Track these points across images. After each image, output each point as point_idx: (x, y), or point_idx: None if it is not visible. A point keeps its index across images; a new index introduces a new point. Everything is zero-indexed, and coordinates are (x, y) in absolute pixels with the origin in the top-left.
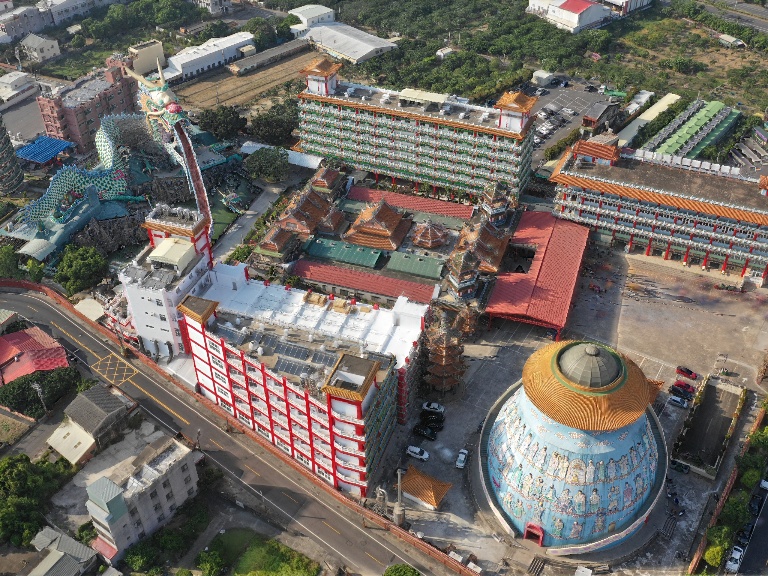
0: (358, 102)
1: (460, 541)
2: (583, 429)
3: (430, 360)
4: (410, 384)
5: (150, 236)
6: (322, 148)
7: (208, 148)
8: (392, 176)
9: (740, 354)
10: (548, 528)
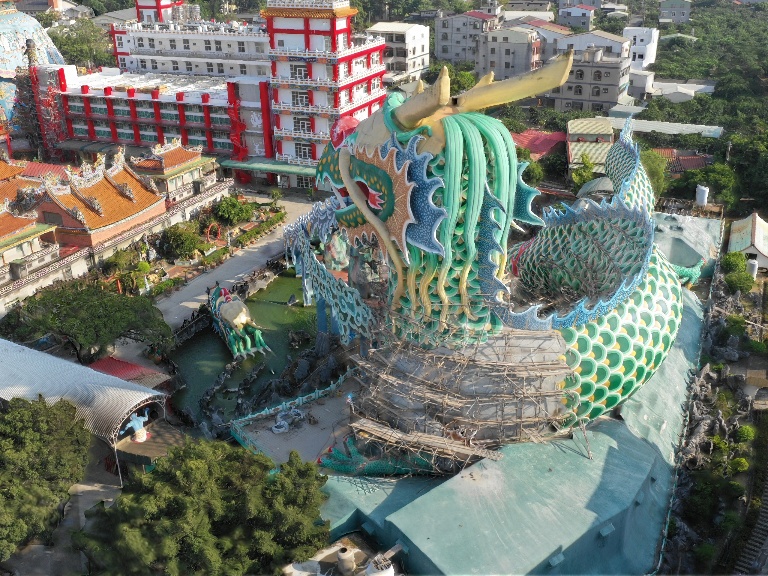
0: None
1: None
2: None
3: None
4: None
5: None
6: None
7: None
8: None
9: None
10: None
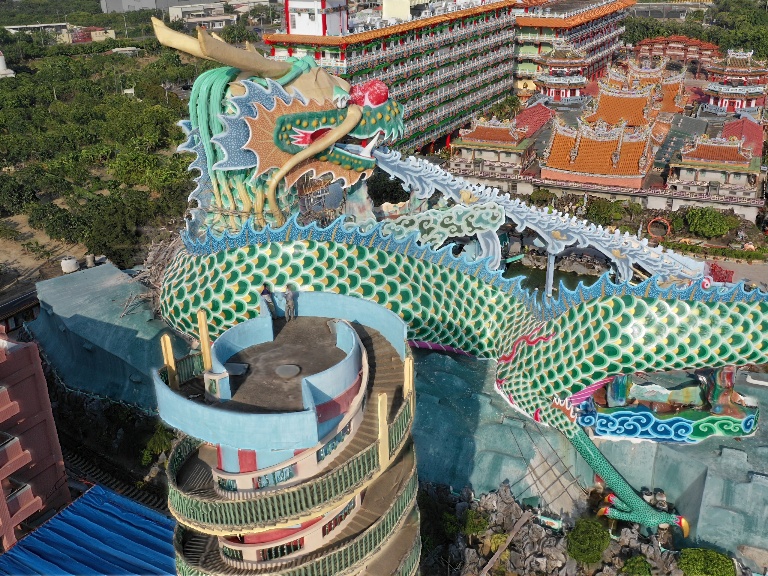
0: None
1: None
2: None
3: None
4: None
5: None
6: None
7: None
8: (434, 140)
9: None
10: None
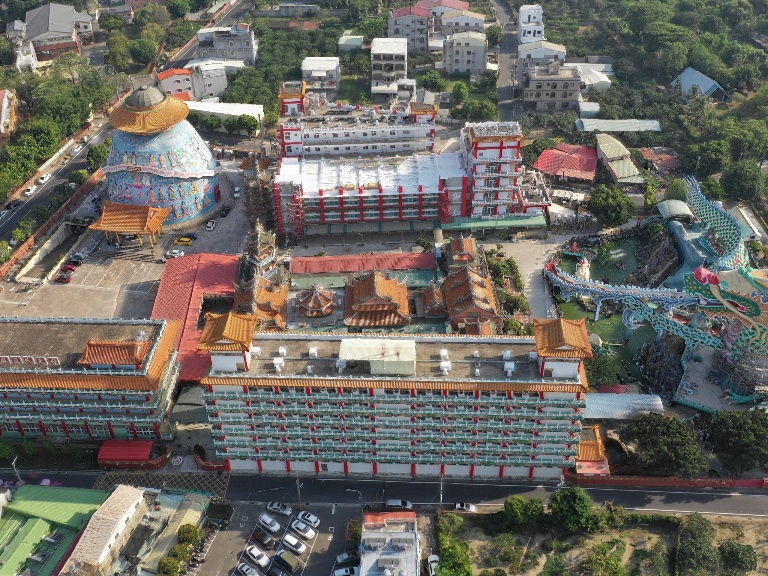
0: (476, 337)
1: (229, 164)
2: None
3: None
4: None
5: None
6: None
7: None
8: None
9: (6, 309)
10: None
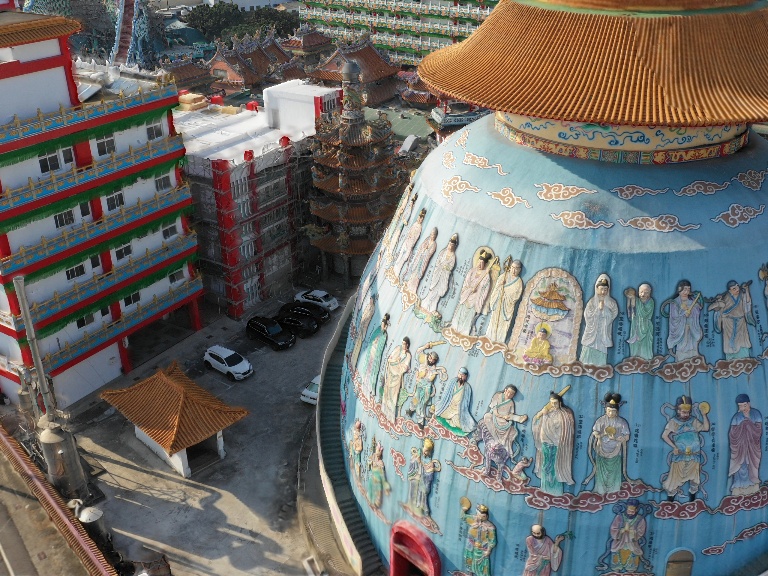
0: None
1: (204, 559)
2: (569, 116)
3: (315, 183)
4: (272, 240)
5: None
6: (326, 29)
7: (190, 47)
8: None
9: None
10: (449, 544)
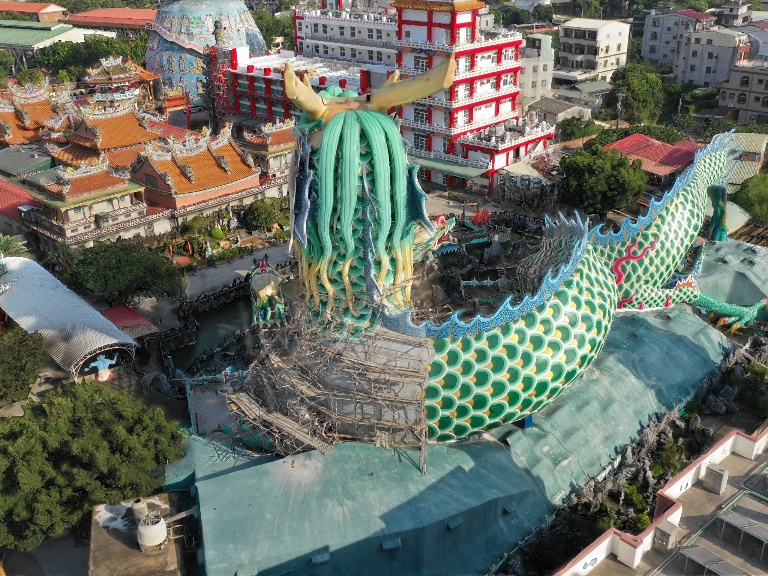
0: None
1: None
2: None
3: None
4: None
5: (475, 26)
6: None
7: None
8: None
9: None
10: None
